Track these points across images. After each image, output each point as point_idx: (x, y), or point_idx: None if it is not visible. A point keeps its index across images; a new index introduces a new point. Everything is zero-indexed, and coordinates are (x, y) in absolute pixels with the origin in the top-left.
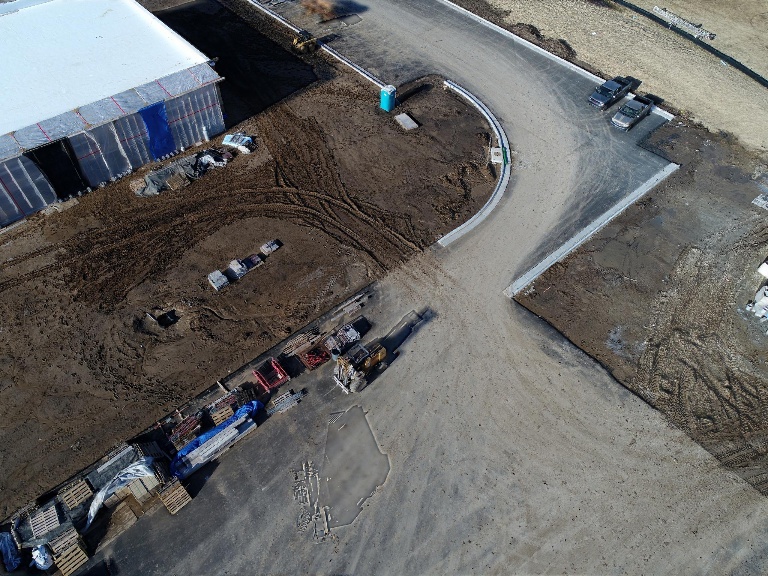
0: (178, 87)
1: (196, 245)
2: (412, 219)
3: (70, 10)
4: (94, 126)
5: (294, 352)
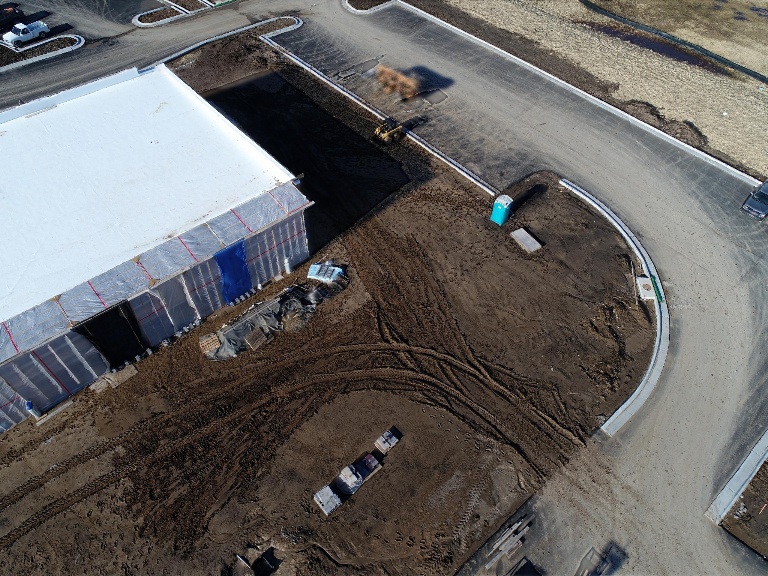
0: (259, 219)
1: (291, 437)
2: (560, 391)
3: (117, 104)
4: (160, 281)
5: None
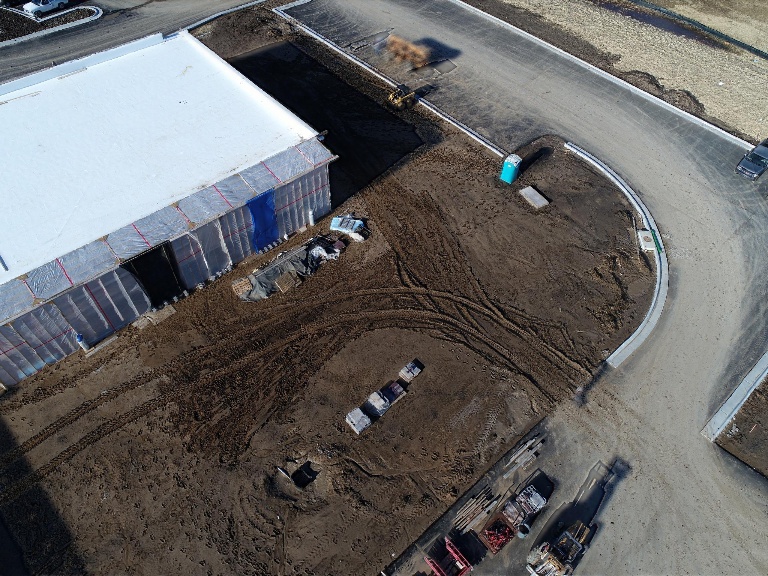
0: (288, 170)
1: (321, 368)
2: (568, 329)
3: (145, 67)
4: (198, 225)
5: (469, 527)
